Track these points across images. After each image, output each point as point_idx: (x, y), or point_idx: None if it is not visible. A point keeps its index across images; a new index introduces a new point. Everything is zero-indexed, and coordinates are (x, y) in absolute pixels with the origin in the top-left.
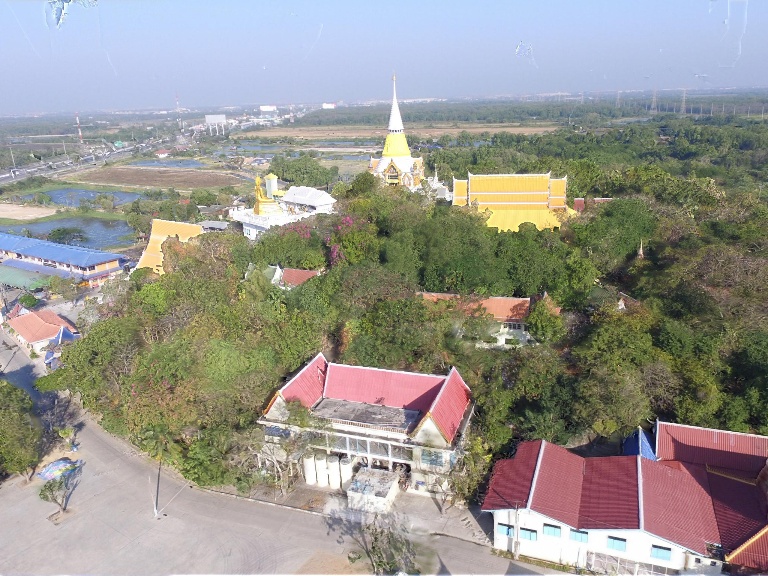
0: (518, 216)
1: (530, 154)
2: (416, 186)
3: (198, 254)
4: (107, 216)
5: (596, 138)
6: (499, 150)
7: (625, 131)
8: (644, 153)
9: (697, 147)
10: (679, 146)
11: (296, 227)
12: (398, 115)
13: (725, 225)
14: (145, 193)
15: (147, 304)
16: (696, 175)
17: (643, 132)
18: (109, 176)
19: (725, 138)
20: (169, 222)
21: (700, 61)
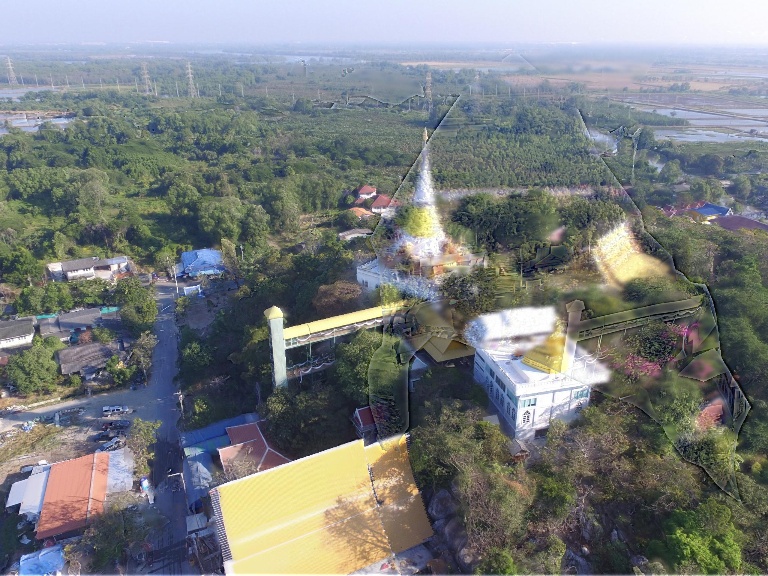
0: None
1: (40, 165)
2: None
3: (588, 468)
4: None
5: (80, 134)
6: (44, 169)
7: (98, 122)
8: (168, 148)
9: (207, 137)
10: (186, 137)
11: None
12: None
13: None
14: None
15: (739, 568)
16: (295, 170)
17: (119, 122)
18: None
19: (209, 124)
20: (274, 471)
21: None
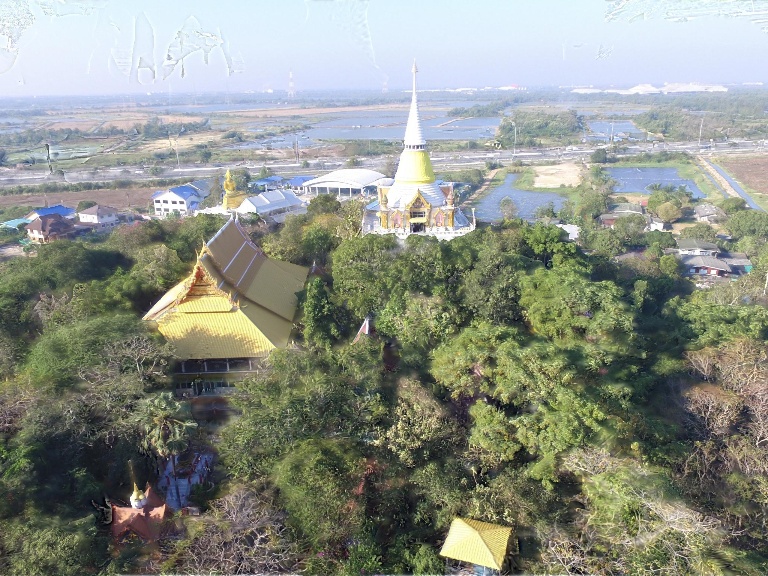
0: (179, 289)
1: None
2: (383, 228)
3: None
4: (574, 199)
5: None
6: None
7: None
8: None
9: None
10: None
11: (181, 222)
12: (412, 124)
13: None
14: (652, 185)
15: None
16: None
17: None
18: (757, 163)
19: None
20: None
21: (278, 42)
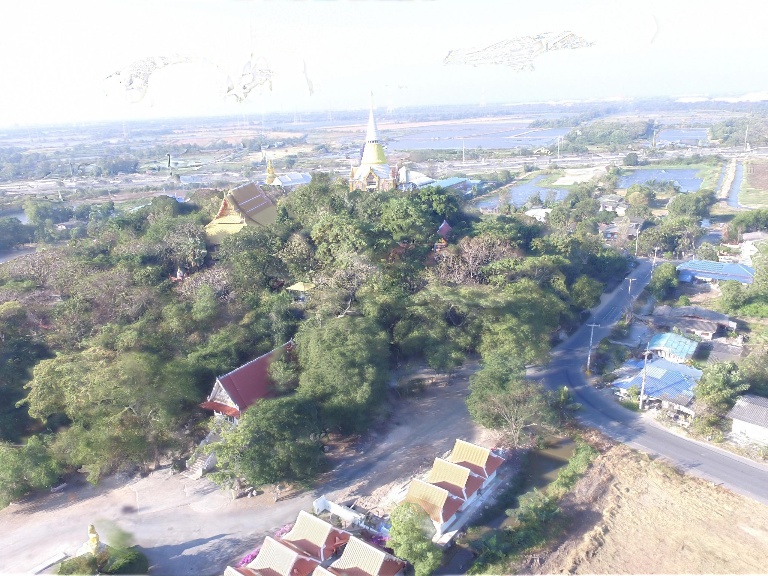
0: None
1: None
2: None
3: None
4: None
5: None
6: None
7: None
8: None
9: None
10: None
11: None
12: (370, 127)
13: (121, 256)
14: (648, 181)
15: None
16: None
17: None
18: None
19: None
20: None
21: None
